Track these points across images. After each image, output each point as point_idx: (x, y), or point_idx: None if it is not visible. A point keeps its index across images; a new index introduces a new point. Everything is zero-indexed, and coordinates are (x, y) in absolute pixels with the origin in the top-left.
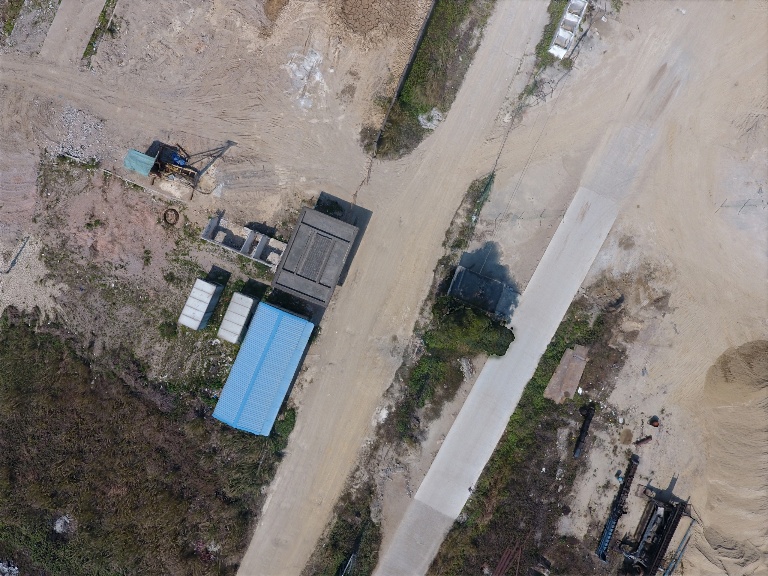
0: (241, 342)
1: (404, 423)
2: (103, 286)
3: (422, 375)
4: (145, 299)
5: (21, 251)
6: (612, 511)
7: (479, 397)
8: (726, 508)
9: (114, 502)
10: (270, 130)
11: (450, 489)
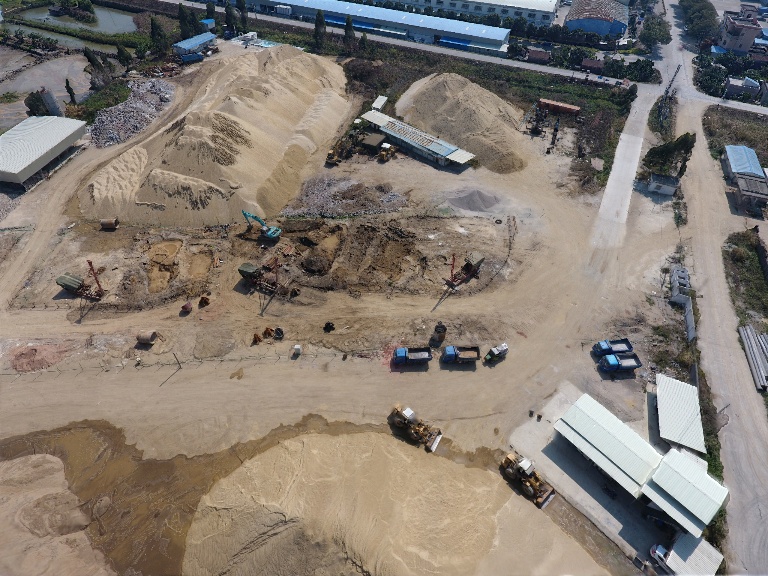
0: None
1: None
2: None
3: None
4: None
5: None
6: None
7: None
8: (510, 129)
9: None
10: None
11: None
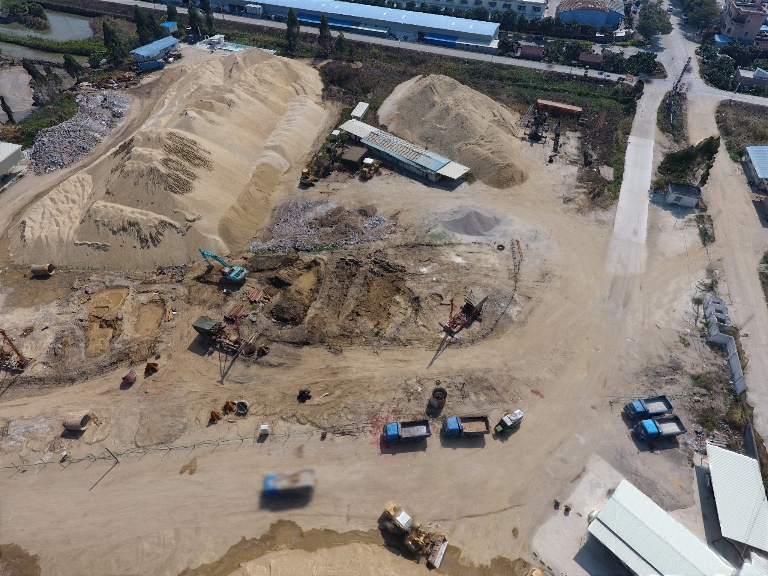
0: None
1: None
2: None
3: None
4: None
5: None
6: None
7: (646, 167)
8: (507, 136)
9: None
10: None
11: None
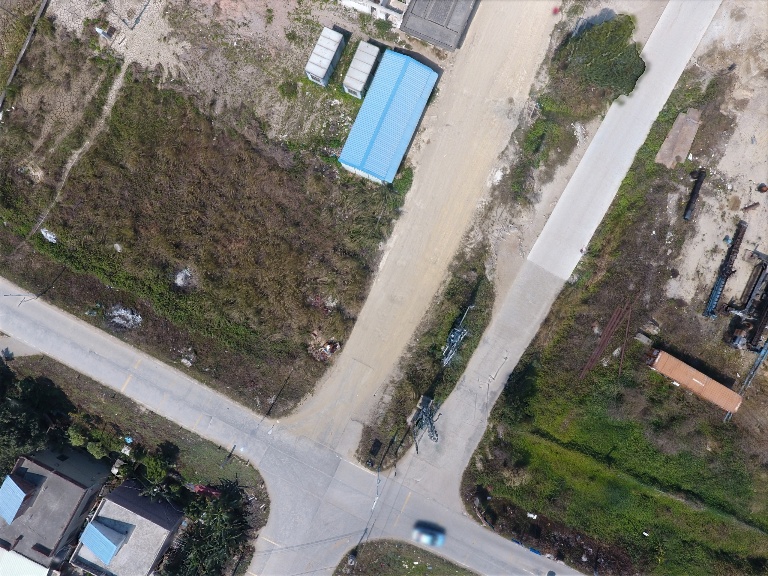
0: (367, 89)
1: (520, 183)
2: (225, 45)
3: (537, 137)
4: (266, 58)
5: (145, 9)
6: (721, 272)
7: (592, 161)
8: None
9: (235, 255)
10: None
11: (562, 251)
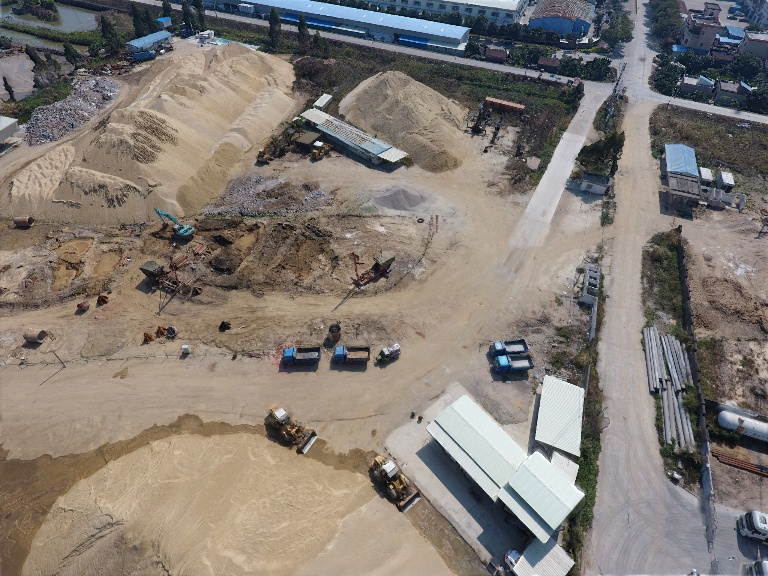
0: (698, 167)
1: None
2: None
3: None
4: None
5: None
6: None
7: None
8: (451, 128)
9: None
10: (741, 243)
11: (571, 138)
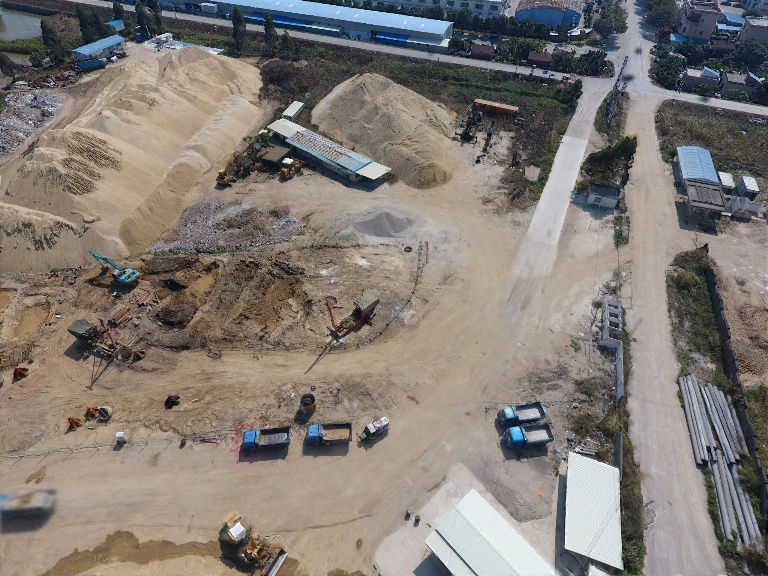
0: None
1: None
2: None
3: None
4: None
5: None
6: None
7: (574, 168)
8: (437, 136)
9: None
10: None
11: None
